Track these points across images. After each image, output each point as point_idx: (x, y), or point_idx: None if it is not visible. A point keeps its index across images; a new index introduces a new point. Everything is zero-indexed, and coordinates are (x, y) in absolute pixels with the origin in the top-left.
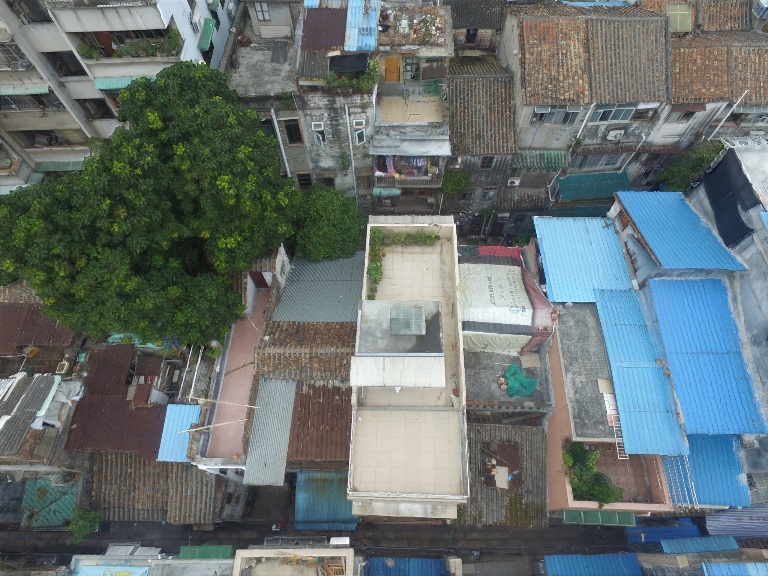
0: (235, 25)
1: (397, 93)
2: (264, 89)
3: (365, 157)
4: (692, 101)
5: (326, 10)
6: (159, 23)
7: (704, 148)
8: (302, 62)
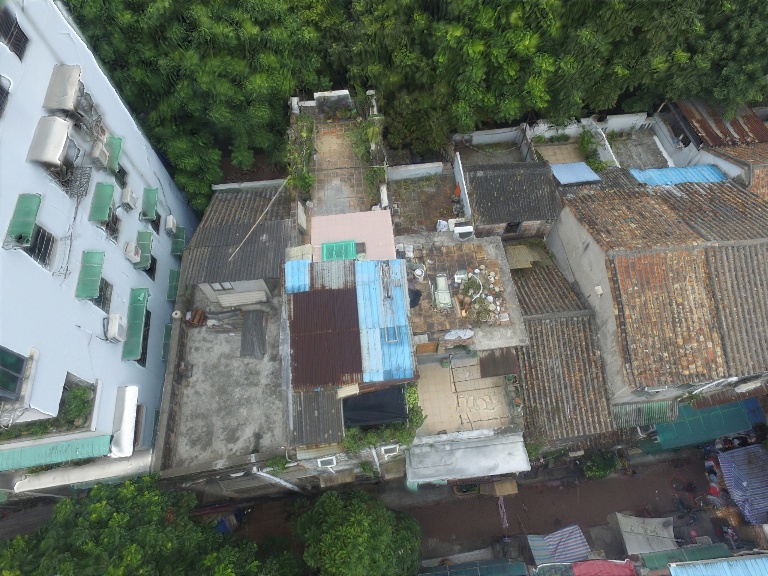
0: (179, 300)
1: (432, 360)
2: (237, 419)
3: (395, 457)
4: None
5: (322, 294)
6: (41, 416)
7: None
8: (298, 413)
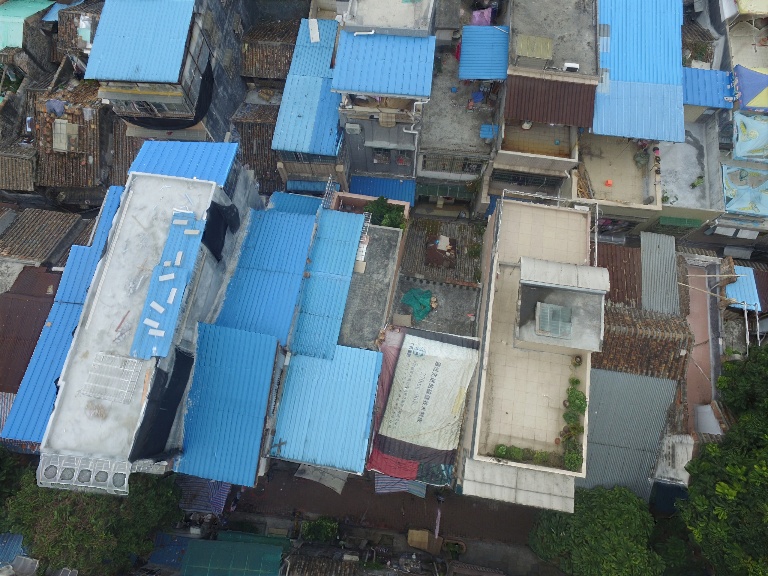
0: None
1: None
2: None
3: None
4: None
5: None
6: None
7: (94, 552)
8: None
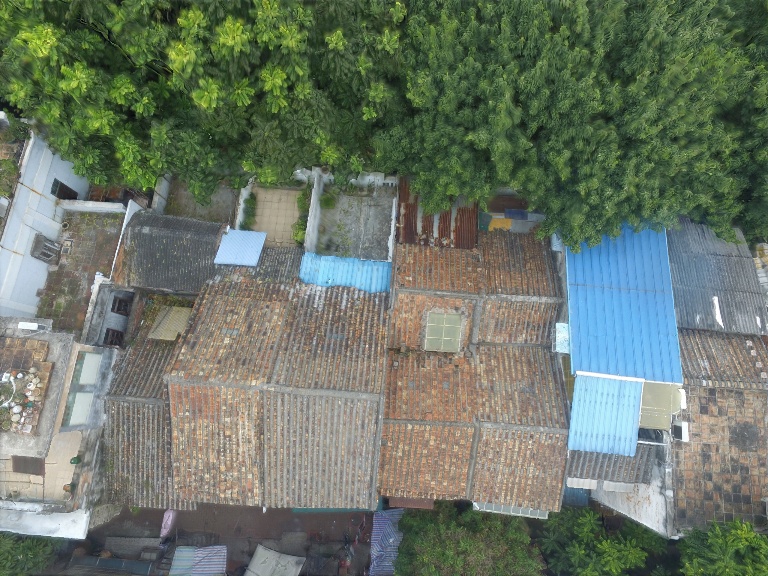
0: None
1: None
2: None
3: None
4: (415, 495)
5: None
6: None
7: None
8: None
